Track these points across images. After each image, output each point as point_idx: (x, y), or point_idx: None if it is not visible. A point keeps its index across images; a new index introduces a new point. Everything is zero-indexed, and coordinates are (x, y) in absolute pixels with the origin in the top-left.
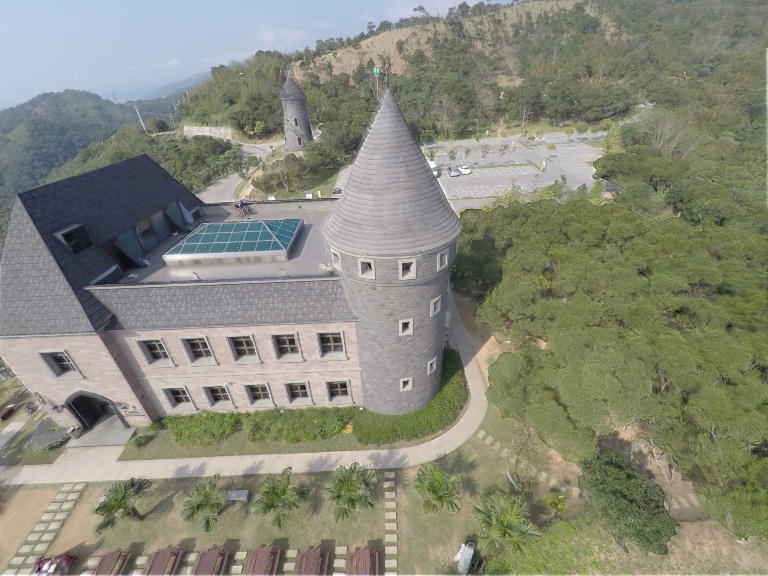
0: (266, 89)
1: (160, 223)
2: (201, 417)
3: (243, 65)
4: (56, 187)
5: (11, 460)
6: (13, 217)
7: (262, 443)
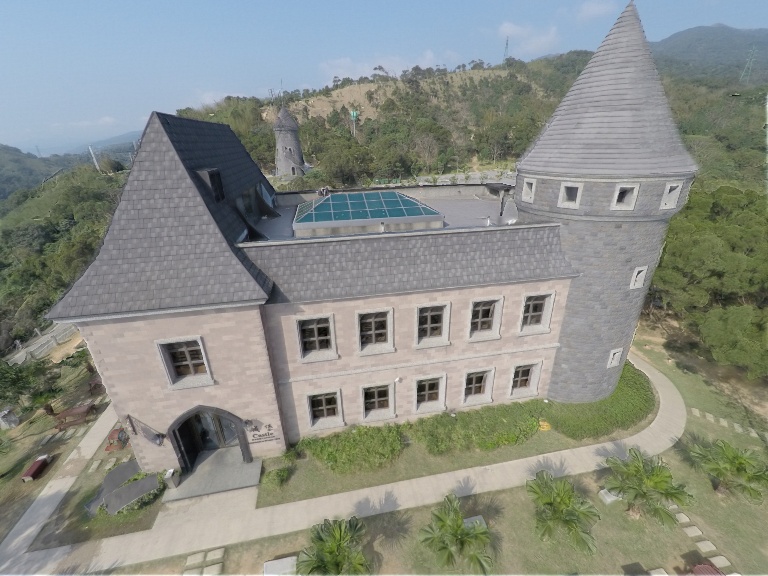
0: (244, 127)
1: (252, 202)
2: (351, 434)
3: (213, 107)
4: (181, 122)
5: (74, 535)
6: (145, 143)
7: (450, 456)
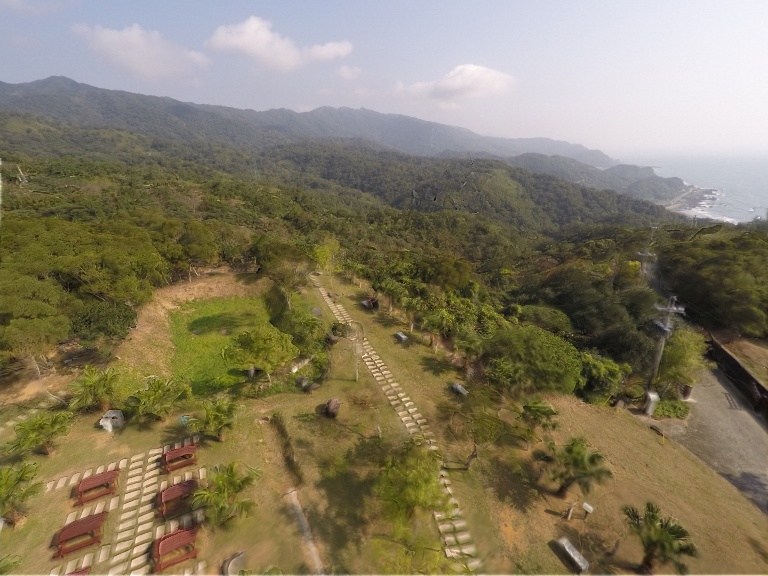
0: None
1: None
2: None
3: None
4: None
5: None
6: None
7: None
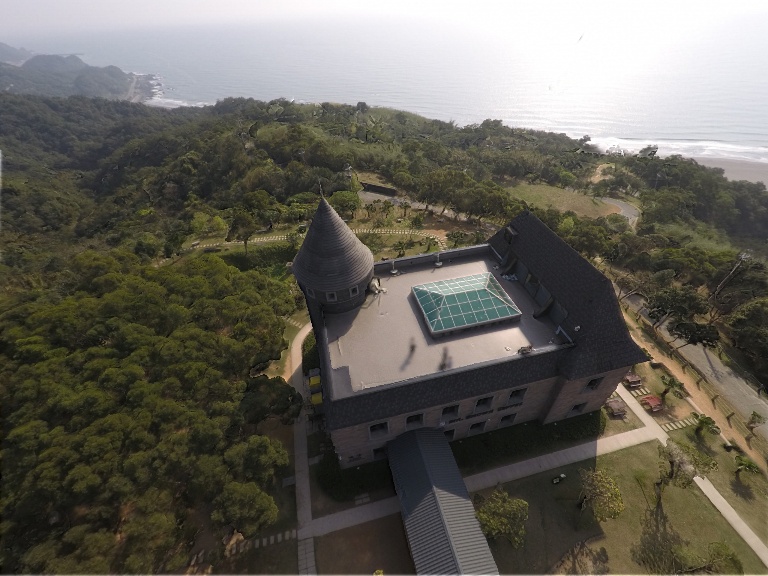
0: None
1: (547, 298)
2: None
3: None
4: None
5: None
6: None
7: None
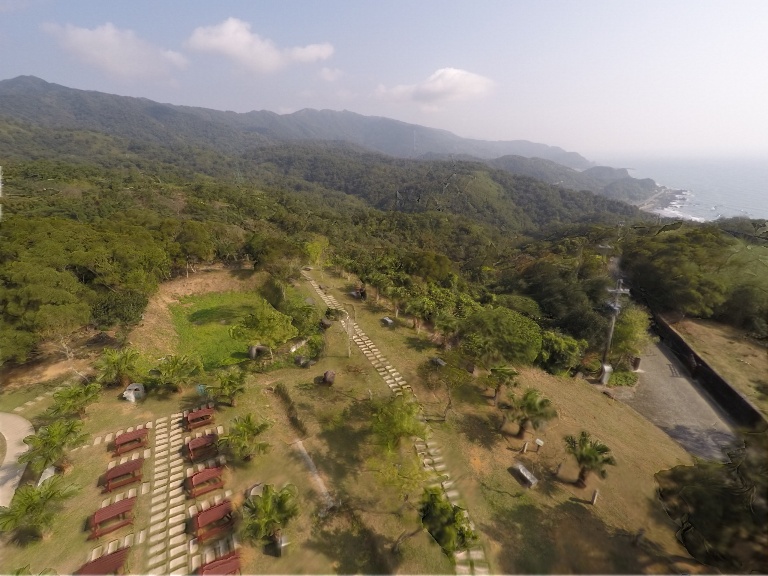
0: None
1: None
2: None
3: None
4: None
5: None
6: None
7: None
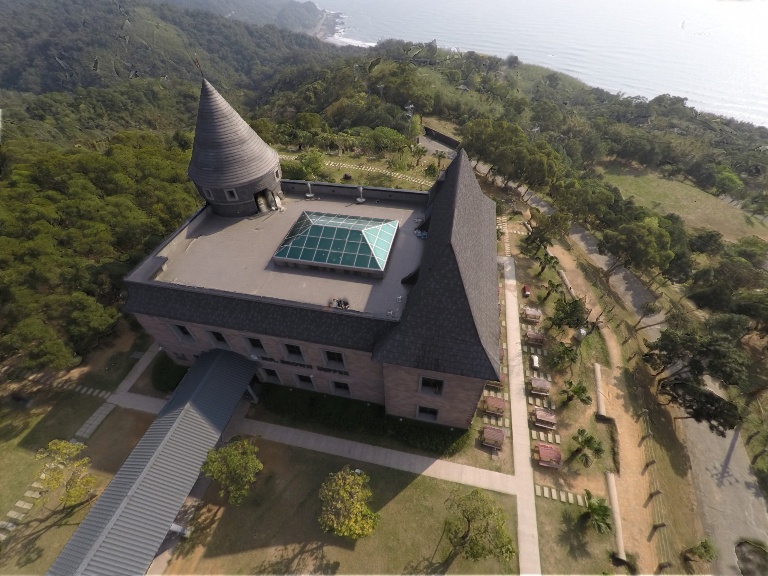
0: None
1: None
2: None
3: None
4: None
5: None
6: None
7: None
